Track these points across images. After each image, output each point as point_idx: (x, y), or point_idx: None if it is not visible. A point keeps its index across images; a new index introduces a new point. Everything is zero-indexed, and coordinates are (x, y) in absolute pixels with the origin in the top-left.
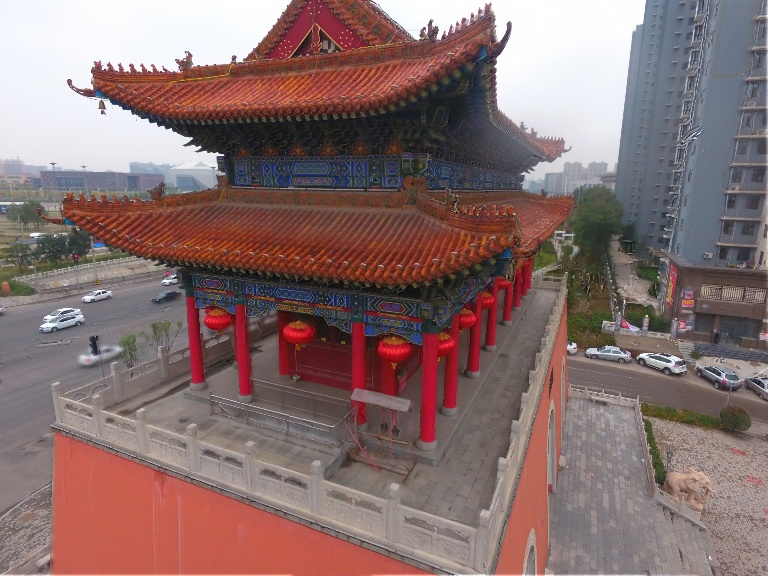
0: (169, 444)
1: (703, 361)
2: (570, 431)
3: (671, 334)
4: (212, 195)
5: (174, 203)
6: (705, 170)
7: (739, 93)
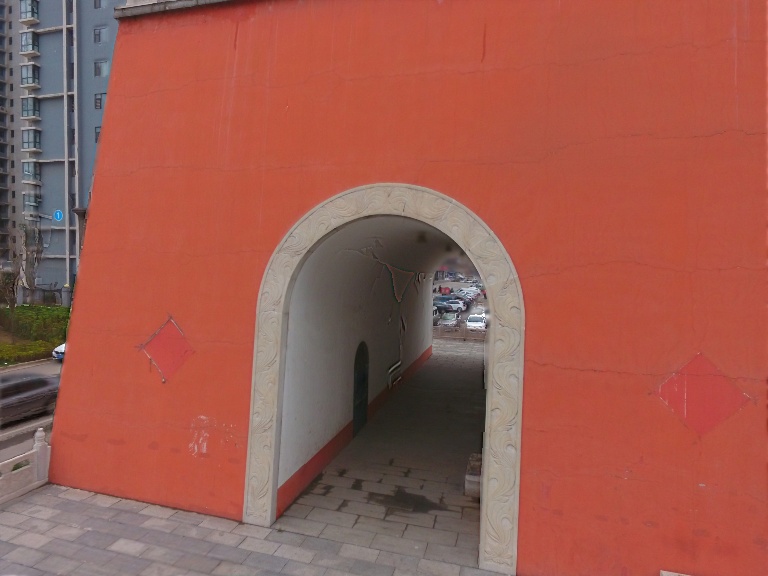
0: None
1: None
2: (459, 353)
3: None
4: None
5: None
6: None
7: None
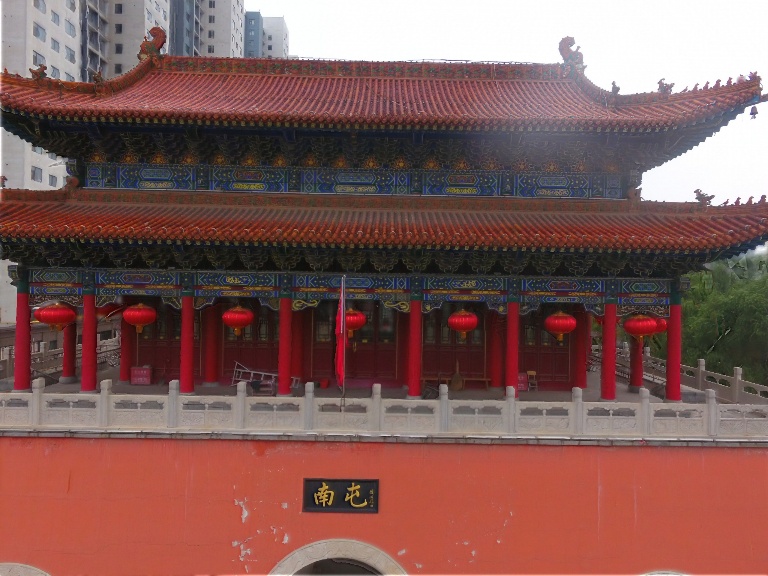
0: (717, 383)
1: None
2: None
3: None
4: (647, 206)
5: (686, 210)
6: None
7: None
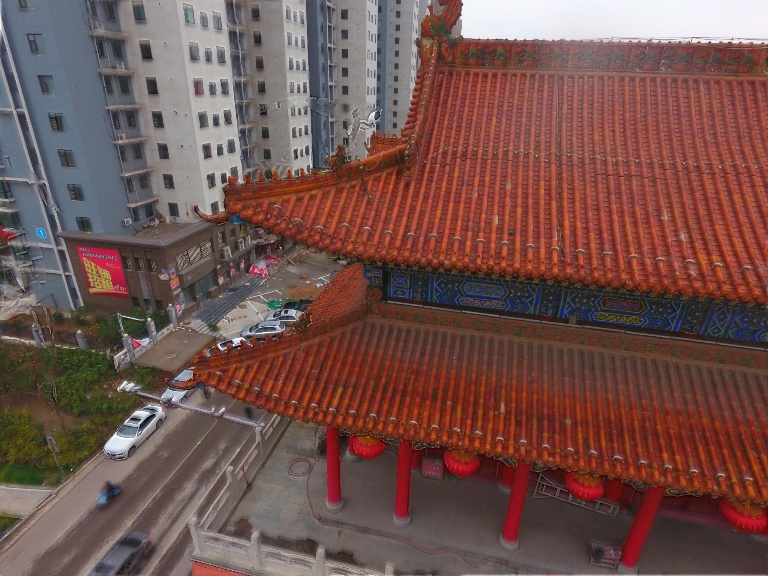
0: None
1: (223, 329)
2: None
3: (173, 323)
4: None
5: None
6: (86, 115)
7: (80, 6)
